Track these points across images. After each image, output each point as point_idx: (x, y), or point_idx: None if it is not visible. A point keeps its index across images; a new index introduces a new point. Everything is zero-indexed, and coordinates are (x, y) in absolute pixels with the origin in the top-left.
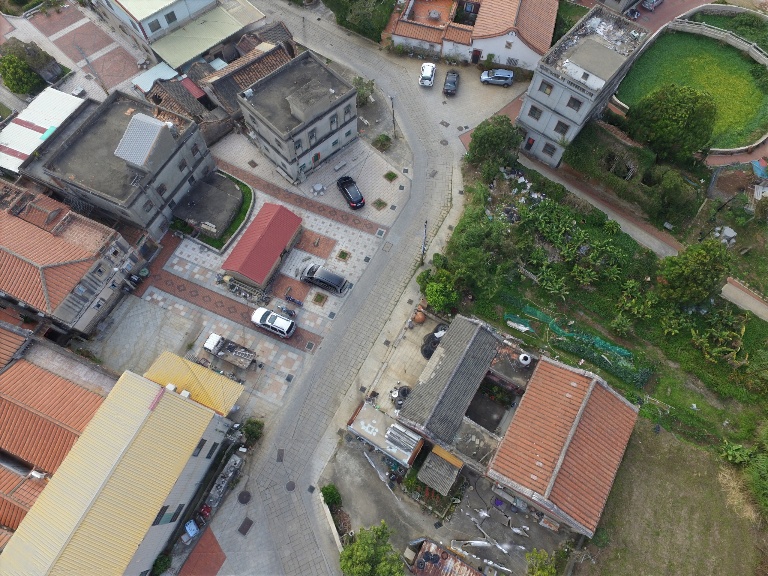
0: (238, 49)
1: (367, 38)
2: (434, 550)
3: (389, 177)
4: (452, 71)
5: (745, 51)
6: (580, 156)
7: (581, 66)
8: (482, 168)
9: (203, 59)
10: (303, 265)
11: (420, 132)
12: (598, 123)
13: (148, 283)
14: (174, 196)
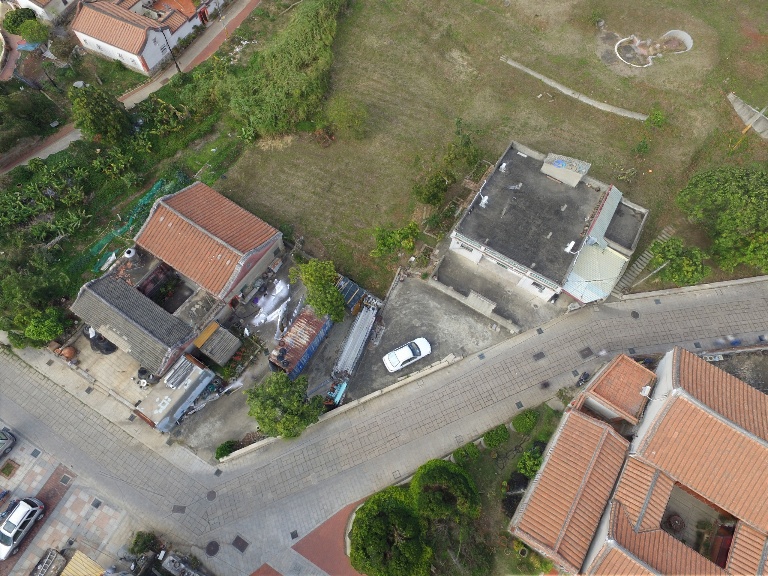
0: None
1: None
2: (277, 352)
3: None
4: None
5: None
6: None
7: None
8: None
9: None
10: None
11: None
12: None
13: None
14: None
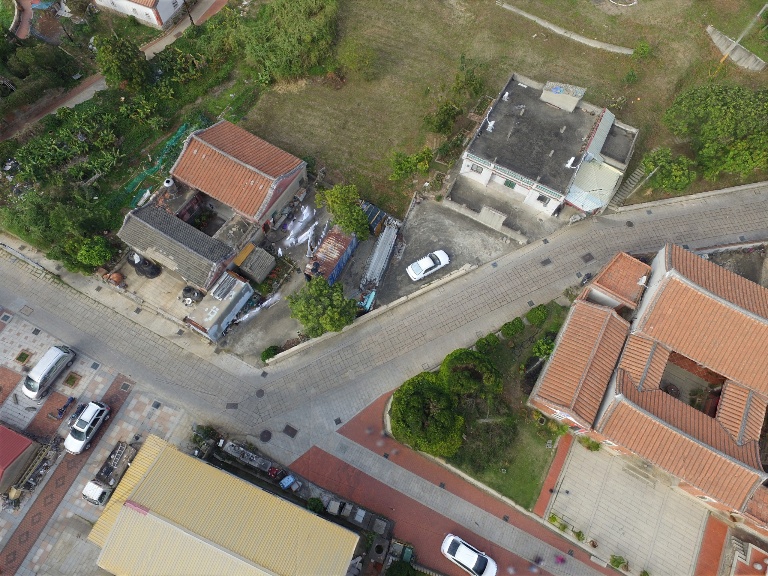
0: None
1: None
2: (311, 266)
3: None
4: None
5: None
6: None
7: None
8: None
9: None
10: (22, 403)
11: None
12: None
13: None
14: None
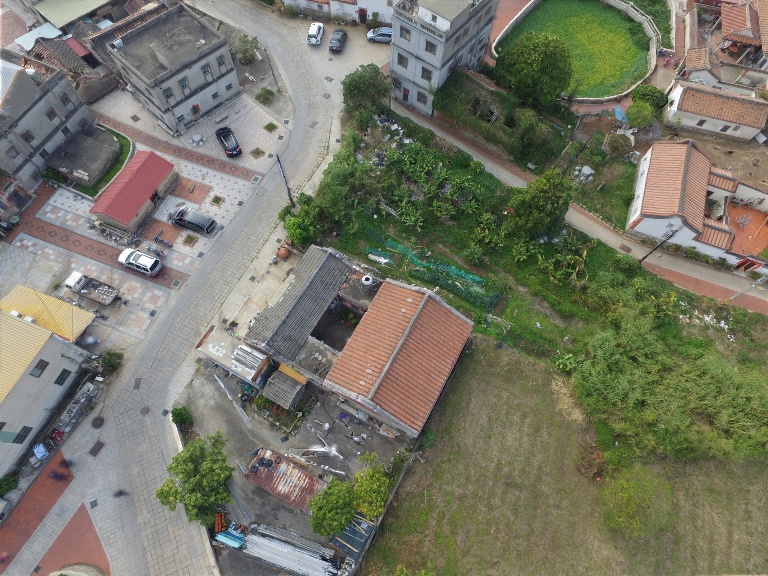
0: (127, 10)
1: (260, 1)
2: (269, 456)
3: (269, 128)
4: (341, 31)
5: (624, 10)
6: (446, 101)
7: (428, 8)
8: (355, 115)
9: (90, 20)
10: (177, 210)
11: (304, 87)
12: (466, 71)
13: (19, 230)
14: (45, 145)
